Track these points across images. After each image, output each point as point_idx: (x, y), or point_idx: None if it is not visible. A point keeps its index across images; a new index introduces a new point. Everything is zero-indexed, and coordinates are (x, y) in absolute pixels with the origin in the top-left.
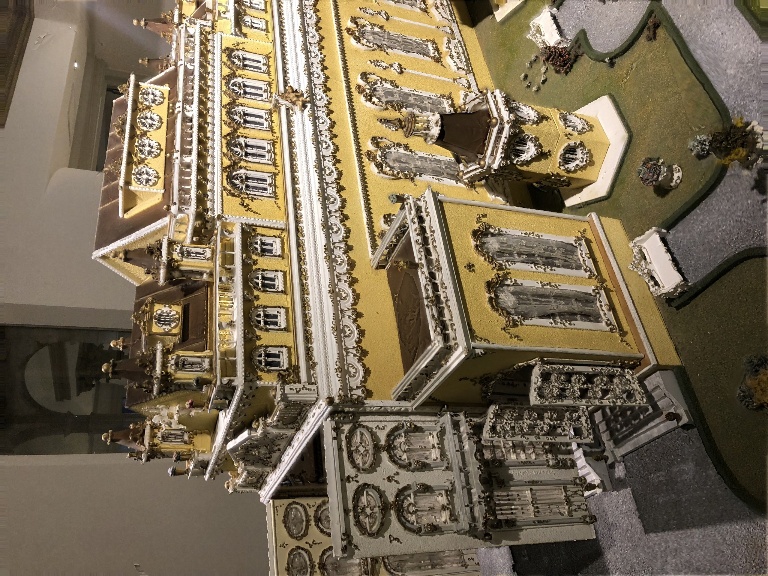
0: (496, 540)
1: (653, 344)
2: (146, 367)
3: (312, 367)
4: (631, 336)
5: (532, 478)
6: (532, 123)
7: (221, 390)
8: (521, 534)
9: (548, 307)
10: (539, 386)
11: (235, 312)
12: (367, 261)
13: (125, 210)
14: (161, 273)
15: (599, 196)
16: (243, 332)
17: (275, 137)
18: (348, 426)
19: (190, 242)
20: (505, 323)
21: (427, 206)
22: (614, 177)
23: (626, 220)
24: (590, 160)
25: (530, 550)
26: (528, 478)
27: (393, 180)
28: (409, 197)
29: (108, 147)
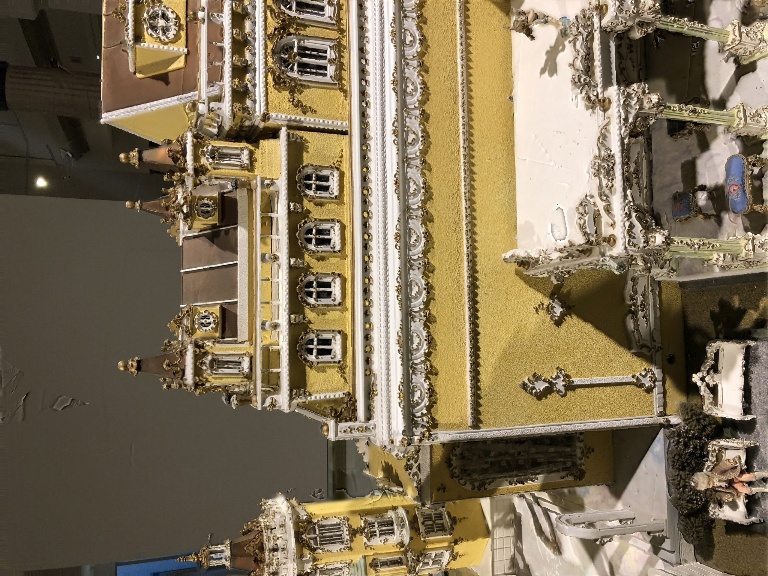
0: None
1: None
2: None
3: None
4: None
5: None
6: None
7: None
8: None
9: None
10: None
11: None
12: None
13: None
14: None
15: None
16: None
17: None
18: None
19: None
20: None
21: None
22: None
23: None
24: None
25: None
26: None
27: None
28: None
29: (105, 26)
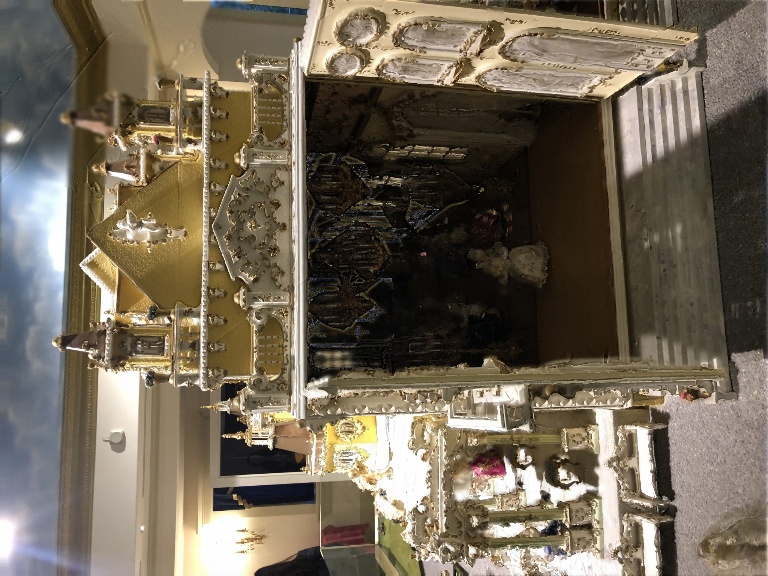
0: None
1: None
2: None
3: None
4: None
5: None
6: None
7: (189, 105)
8: None
9: None
10: None
11: None
12: None
13: None
14: (141, 164)
15: None
16: None
17: None
18: None
19: None
20: None
21: None
22: None
23: None
24: None
25: (746, 286)
26: None
27: None
28: None
29: None
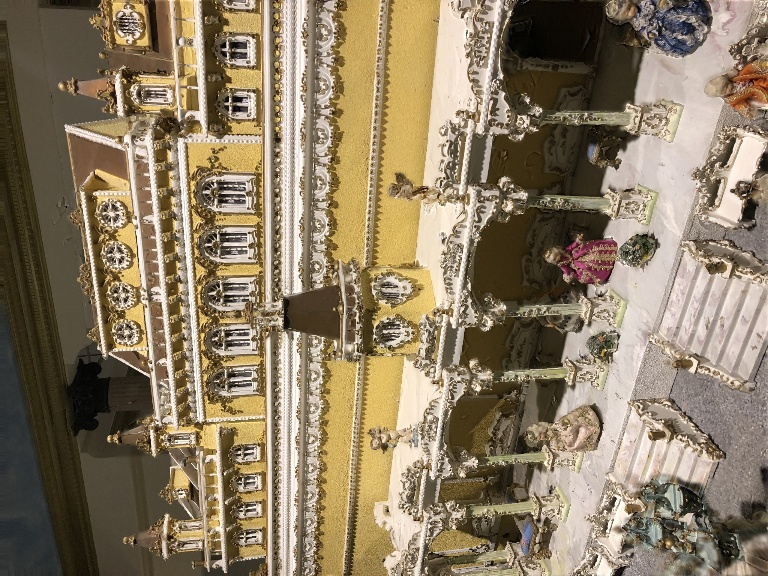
0: None
1: None
2: None
3: None
4: None
5: None
6: None
7: None
8: None
9: None
10: None
11: None
12: None
13: None
14: None
15: None
16: None
17: None
18: None
19: None
20: None
21: None
22: None
23: None
24: None
25: None
26: None
27: None
28: None
29: None
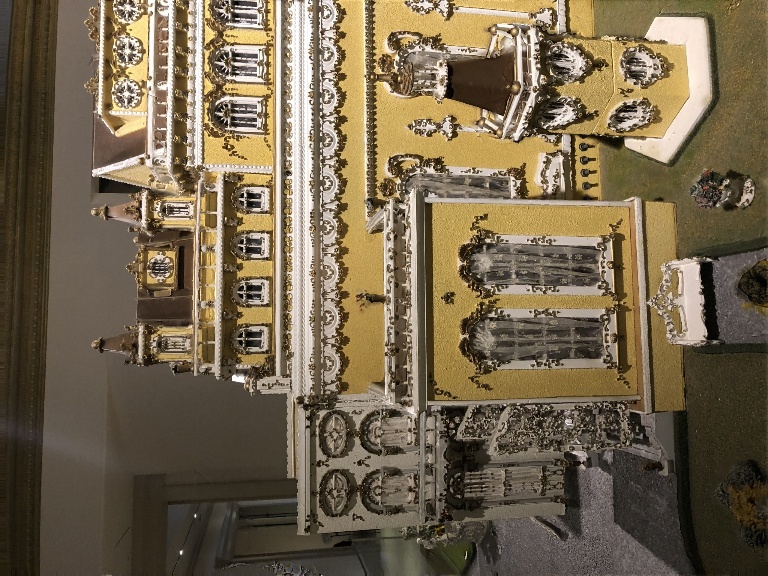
0: (459, 517)
1: (656, 385)
2: (129, 351)
3: (288, 358)
4: (634, 371)
5: (511, 458)
6: (574, 80)
7: None
8: (486, 512)
9: (534, 346)
10: (503, 434)
11: (215, 289)
12: (362, 223)
13: (115, 127)
14: None
15: (660, 160)
16: (221, 315)
17: (270, 37)
18: (324, 412)
19: (177, 184)
20: (475, 371)
21: (410, 213)
22: (682, 145)
23: (681, 209)
24: (655, 117)
25: None
26: (506, 459)
27: (411, 99)
28: (389, 200)
29: None
